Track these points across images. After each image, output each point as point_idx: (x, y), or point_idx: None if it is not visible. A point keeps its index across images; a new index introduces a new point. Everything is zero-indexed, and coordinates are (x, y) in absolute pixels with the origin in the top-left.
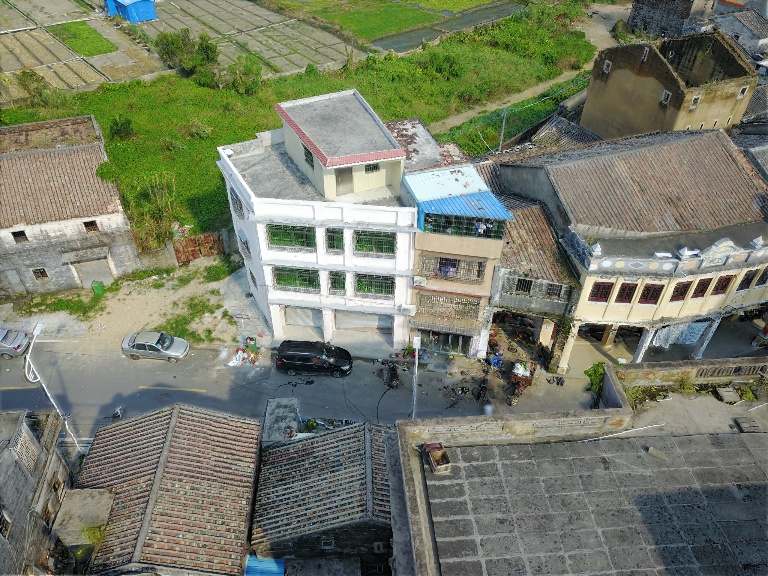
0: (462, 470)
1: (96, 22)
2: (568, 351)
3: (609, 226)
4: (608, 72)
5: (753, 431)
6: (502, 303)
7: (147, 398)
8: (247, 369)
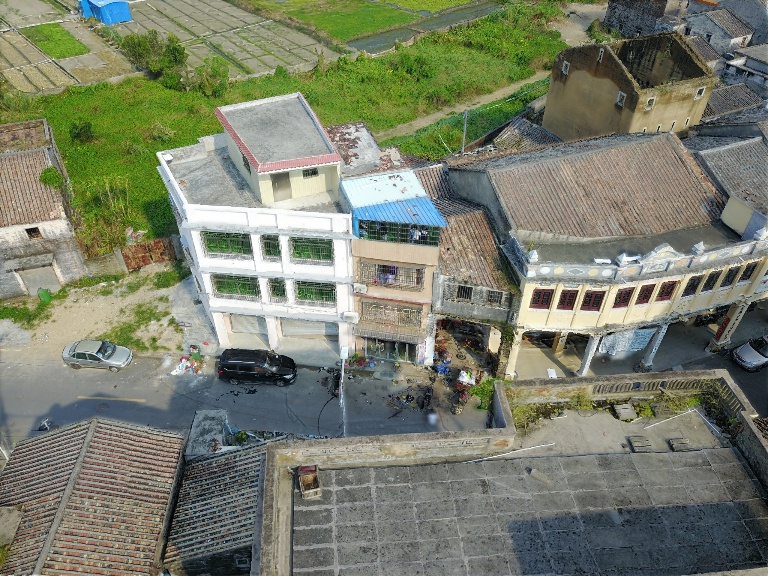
0: (333, 495)
1: (70, 24)
2: (514, 358)
3: (550, 231)
4: (566, 73)
5: (644, 451)
6: (444, 310)
7: (85, 408)
8: (190, 378)
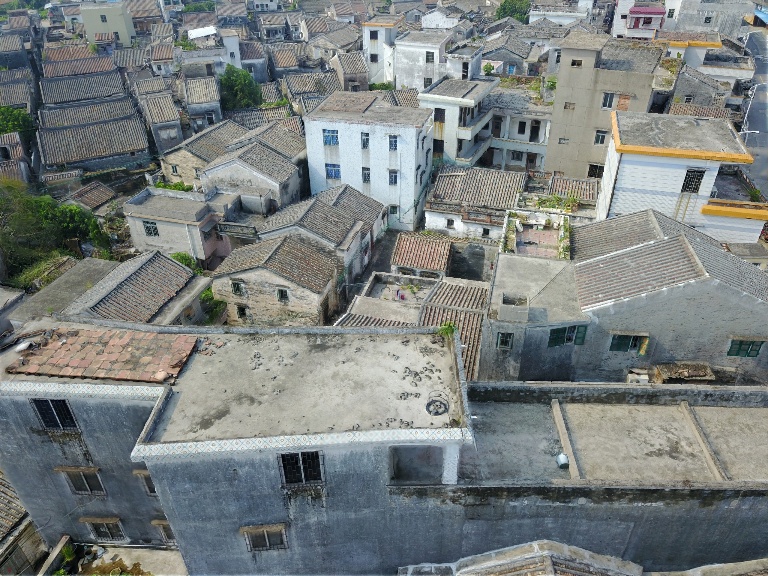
0: (654, 52)
1: None
2: None
3: None
4: None
5: None
6: None
7: None
8: None
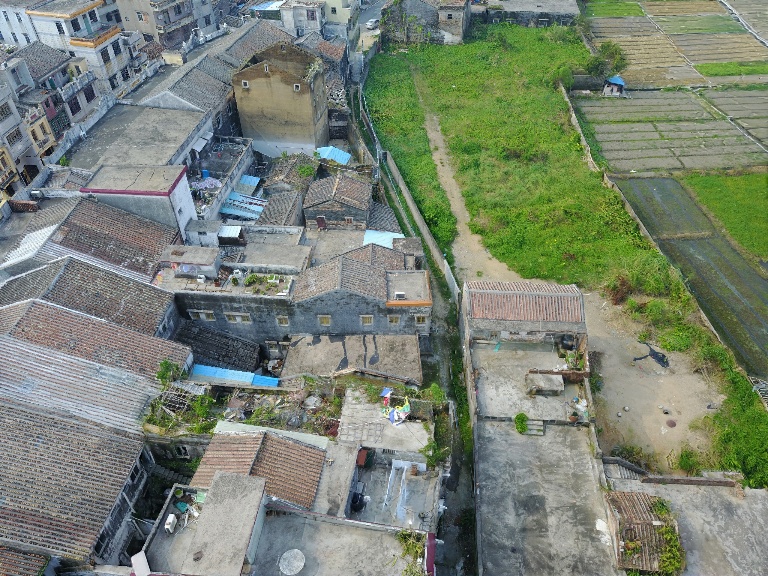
0: None
1: None
2: None
3: None
4: None
5: None
6: None
7: None
8: None
